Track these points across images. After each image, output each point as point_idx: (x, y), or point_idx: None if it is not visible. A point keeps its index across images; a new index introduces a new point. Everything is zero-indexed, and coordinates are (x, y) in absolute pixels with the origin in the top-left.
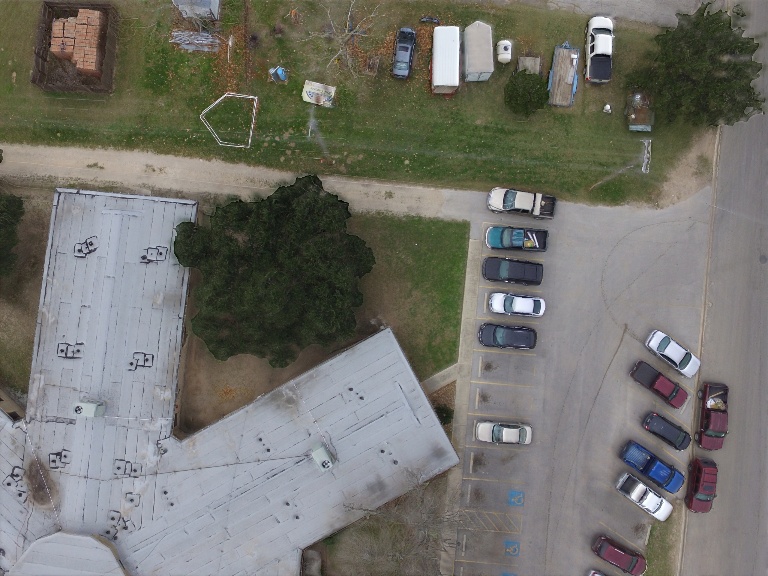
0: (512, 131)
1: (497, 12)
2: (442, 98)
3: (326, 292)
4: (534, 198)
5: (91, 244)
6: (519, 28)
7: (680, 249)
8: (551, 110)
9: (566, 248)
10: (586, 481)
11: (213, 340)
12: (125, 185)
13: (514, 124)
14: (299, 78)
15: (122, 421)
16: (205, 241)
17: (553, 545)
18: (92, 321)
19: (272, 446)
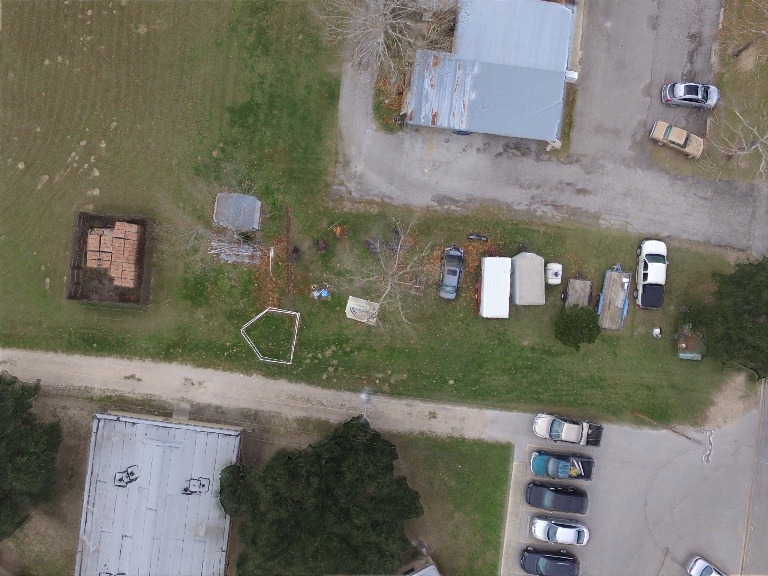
0: (560, 353)
1: (547, 229)
2: (489, 318)
3: (376, 557)
4: (582, 430)
5: (132, 474)
6: (570, 246)
7: (725, 473)
8: None
9: (611, 472)
10: None
11: None
12: (163, 398)
13: (562, 346)
14: (343, 293)
15: None
16: (253, 498)
17: None
18: (134, 552)
19: None
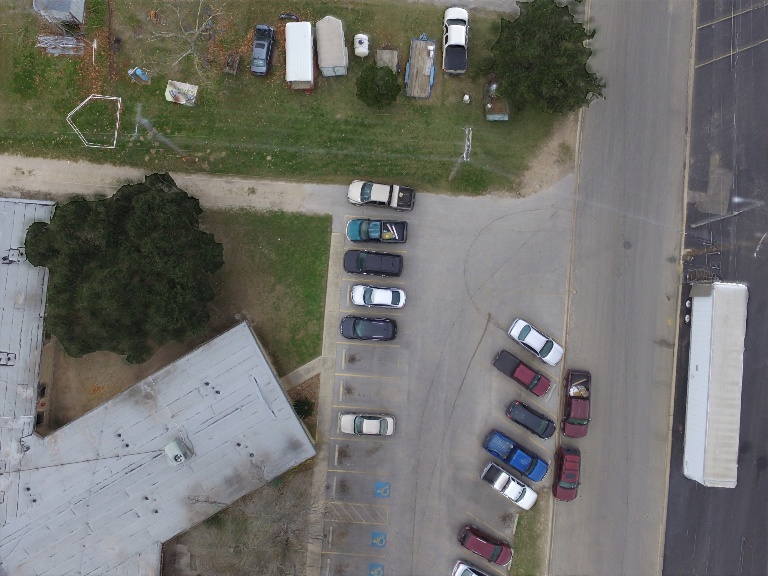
0: (372, 124)
1: (355, 6)
2: (302, 93)
3: (166, 287)
4: (390, 190)
5: None
6: (378, 22)
7: (543, 237)
8: (411, 102)
9: (428, 239)
10: (452, 471)
11: (64, 338)
12: None
13: (374, 117)
14: (162, 78)
15: None
16: (50, 240)
17: (420, 536)
18: None
19: (131, 441)
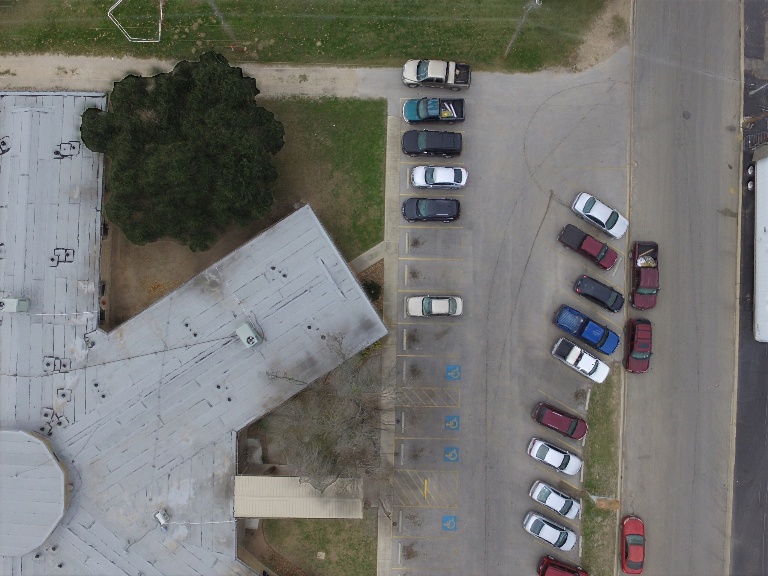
0: (423, 3)
1: None
2: None
3: (232, 160)
4: (447, 65)
5: (3, 144)
6: None
7: (601, 111)
8: None
9: (486, 118)
10: (522, 350)
11: (127, 223)
12: (38, 90)
13: None
14: None
15: (48, 318)
16: (109, 121)
17: (493, 416)
18: (10, 221)
19: (199, 331)
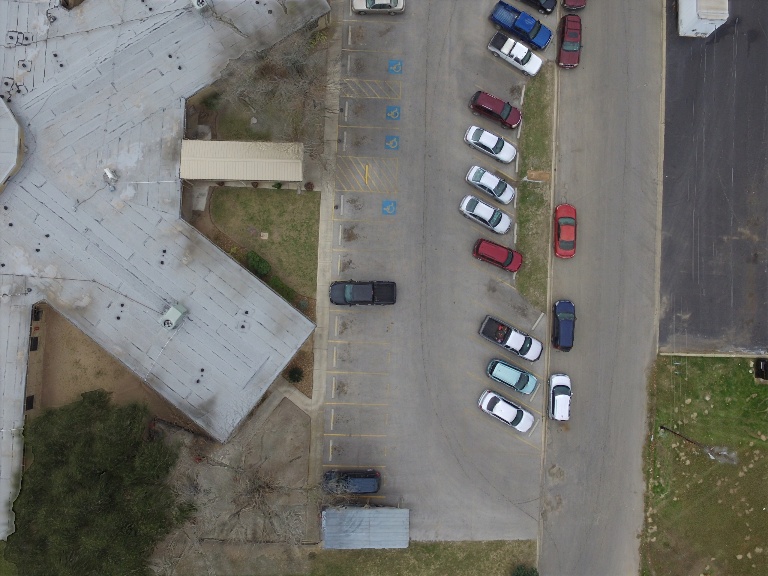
0: None
1: None
2: None
3: None
4: None
5: None
6: None
7: None
8: None
9: None
10: (460, 48)
11: None
12: None
13: None
14: None
15: None
16: None
17: (432, 108)
18: None
19: (154, 6)
